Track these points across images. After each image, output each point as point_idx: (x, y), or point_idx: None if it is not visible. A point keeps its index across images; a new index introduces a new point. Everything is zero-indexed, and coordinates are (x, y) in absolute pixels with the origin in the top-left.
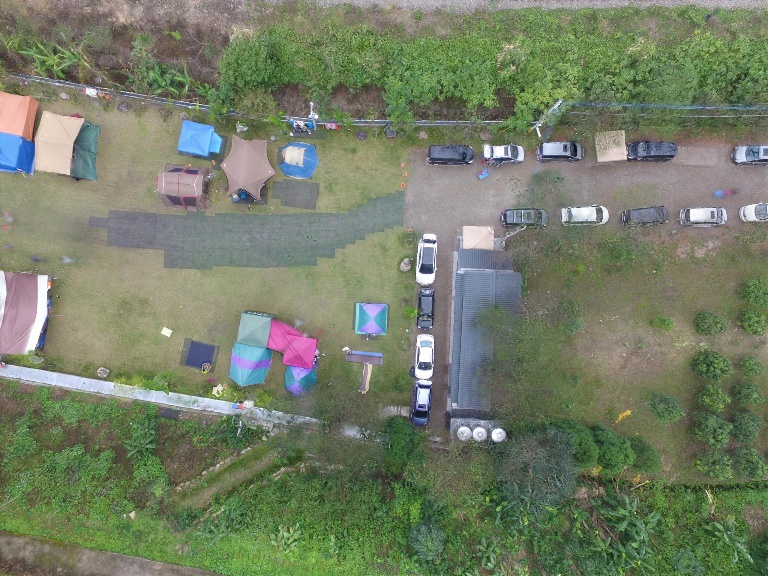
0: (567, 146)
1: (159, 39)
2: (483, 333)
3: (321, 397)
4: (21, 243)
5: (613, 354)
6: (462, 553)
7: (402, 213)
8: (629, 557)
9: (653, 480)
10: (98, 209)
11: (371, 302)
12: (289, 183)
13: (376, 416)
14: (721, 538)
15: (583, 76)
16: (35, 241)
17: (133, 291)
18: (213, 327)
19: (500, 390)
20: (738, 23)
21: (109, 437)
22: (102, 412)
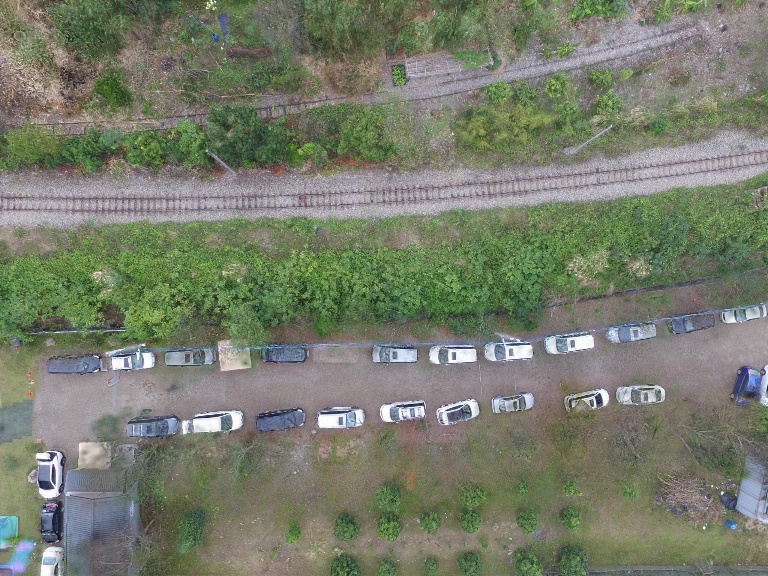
0: (190, 355)
1: None
2: (84, 562)
3: None
4: None
5: (251, 559)
6: None
7: (31, 422)
8: None
9: None
10: None
11: (0, 514)
12: None
13: None
14: None
15: (195, 290)
16: None
17: None
18: None
19: None
20: (352, 232)
21: None
22: None
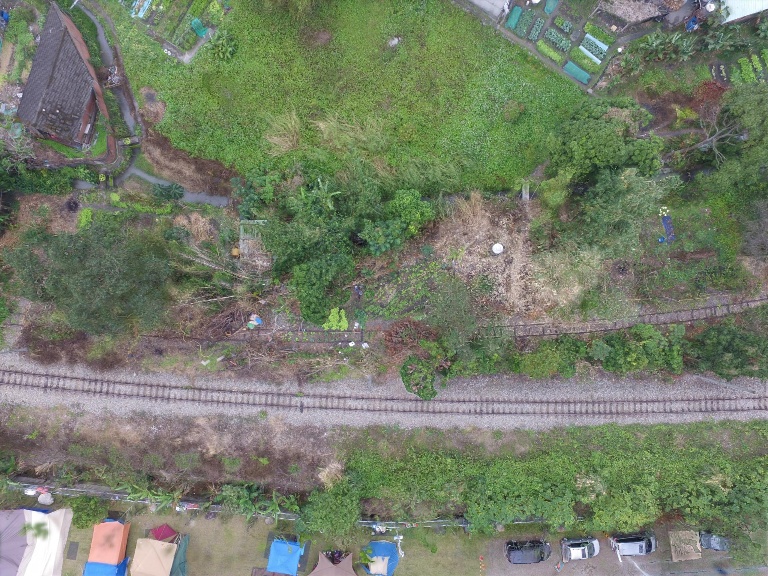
0: (643, 546)
1: (247, 462)
2: None
3: None
4: None
5: None
6: None
7: None
8: None
9: None
10: None
11: None
12: None
13: None
14: None
15: (659, 488)
16: None
17: None
18: None
19: None
20: None
21: None
22: None
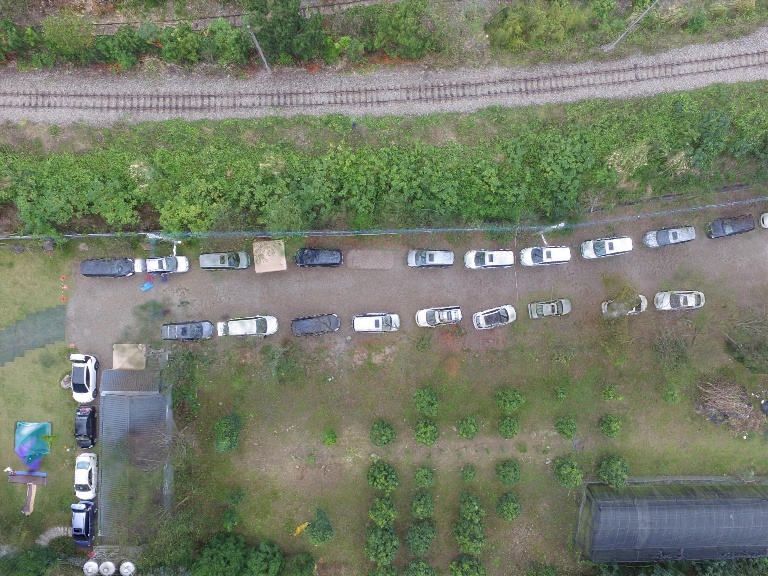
0: (224, 257)
1: None
2: (120, 460)
3: None
4: None
5: (286, 466)
6: None
7: (63, 328)
8: None
9: None
10: None
11: (33, 421)
12: None
13: (43, 537)
14: None
15: (230, 188)
16: None
17: None
18: None
19: (137, 519)
20: (389, 130)
21: None
22: None
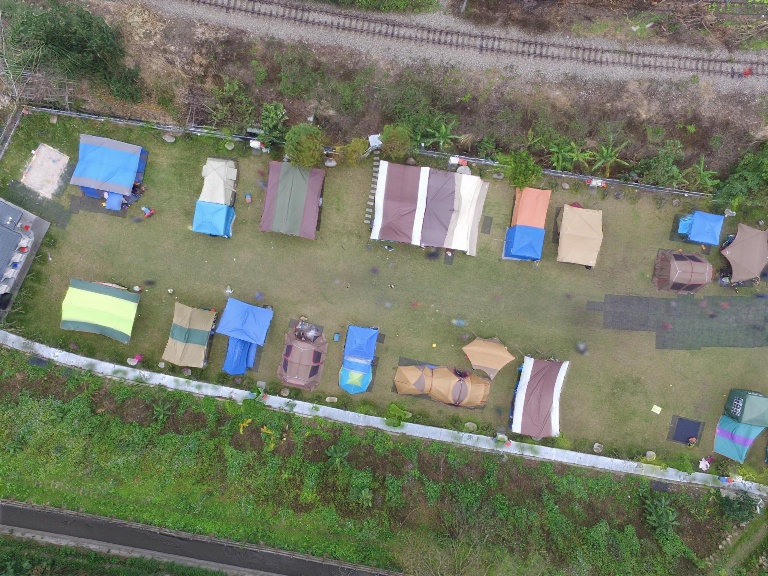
0: None
1: (670, 132)
2: None
3: None
4: (524, 327)
5: None
6: None
7: None
8: None
9: None
10: (595, 294)
11: None
12: None
13: None
14: None
15: None
16: (538, 325)
17: (626, 371)
18: (699, 404)
19: None
20: None
21: (618, 511)
22: (605, 486)
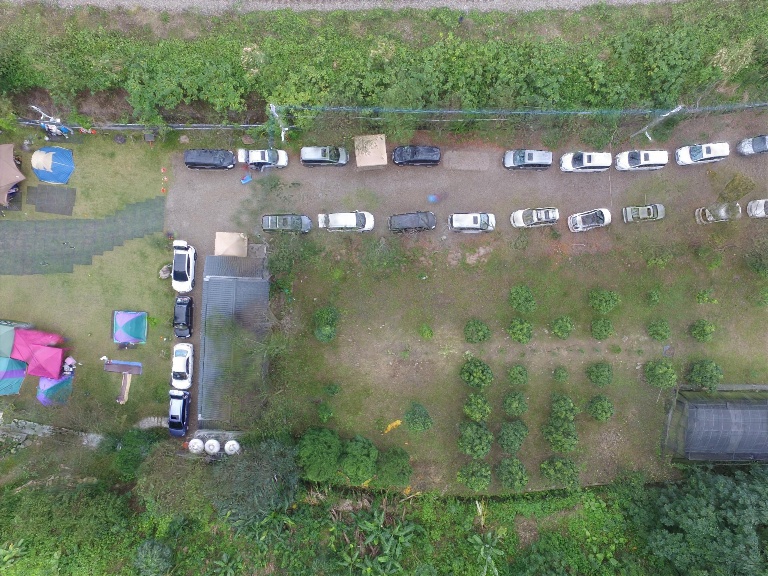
0: (326, 150)
1: None
2: (224, 342)
3: (77, 408)
4: None
5: (380, 363)
6: (204, 569)
7: (162, 219)
8: (374, 572)
9: (423, 491)
10: None
11: (130, 310)
12: (44, 188)
13: (136, 427)
14: (479, 551)
15: (336, 79)
16: None
17: None
18: None
19: None
20: (494, 25)
21: None
22: None
